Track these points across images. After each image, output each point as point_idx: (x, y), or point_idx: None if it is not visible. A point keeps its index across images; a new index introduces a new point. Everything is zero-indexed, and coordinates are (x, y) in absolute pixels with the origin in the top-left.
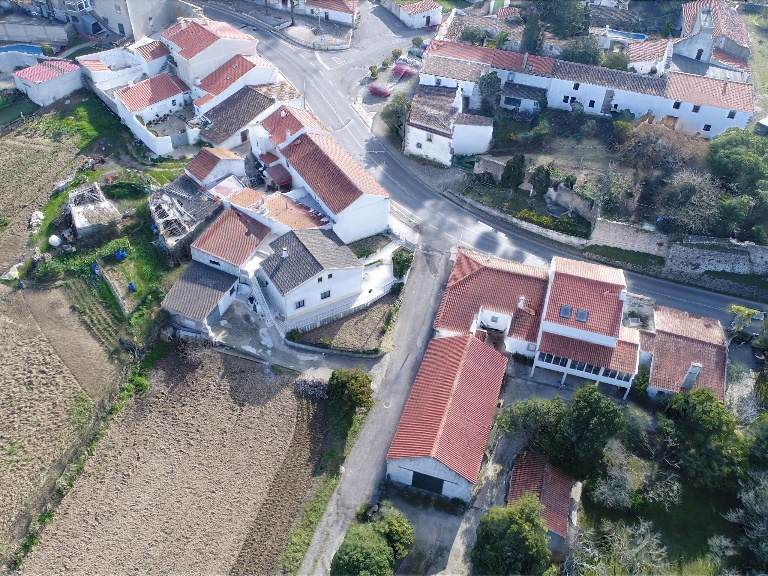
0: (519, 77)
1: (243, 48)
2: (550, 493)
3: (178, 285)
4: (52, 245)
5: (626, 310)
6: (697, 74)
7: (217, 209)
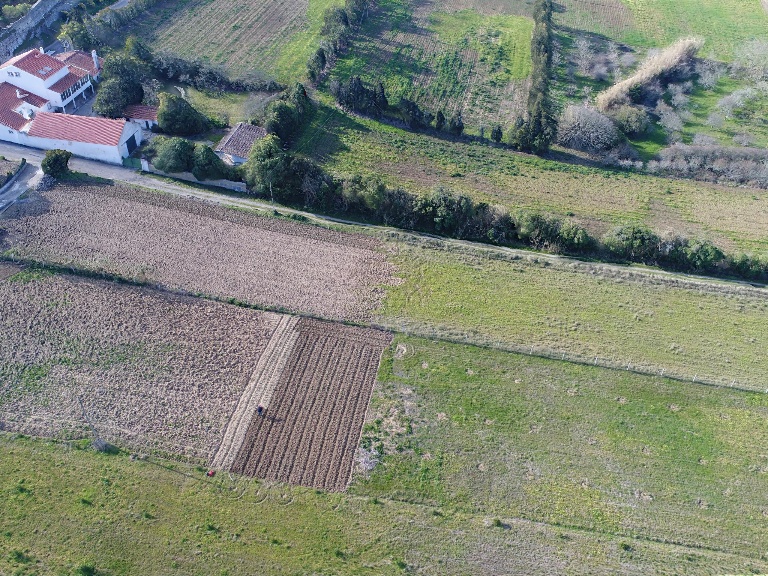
0: None
1: None
2: None
3: None
4: None
5: None
6: None
7: None
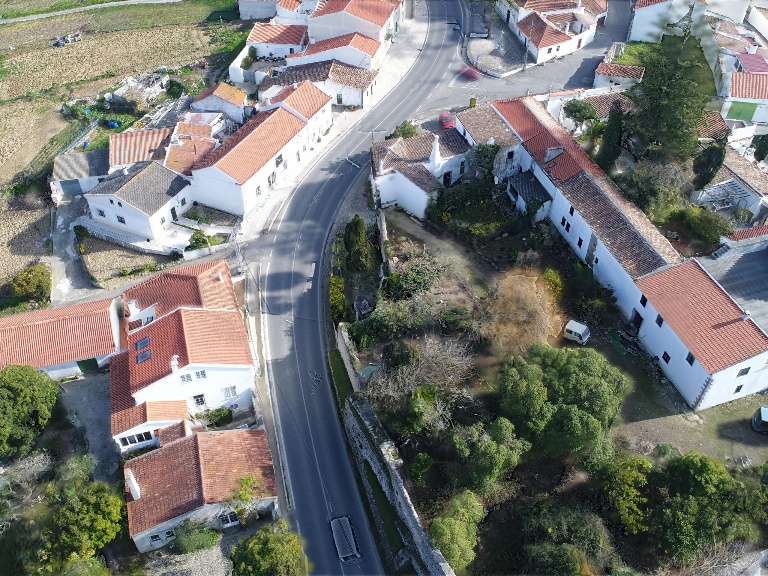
0: (538, 169)
1: (366, 28)
2: None
3: (80, 154)
4: None
5: None
6: (742, 289)
7: (171, 126)
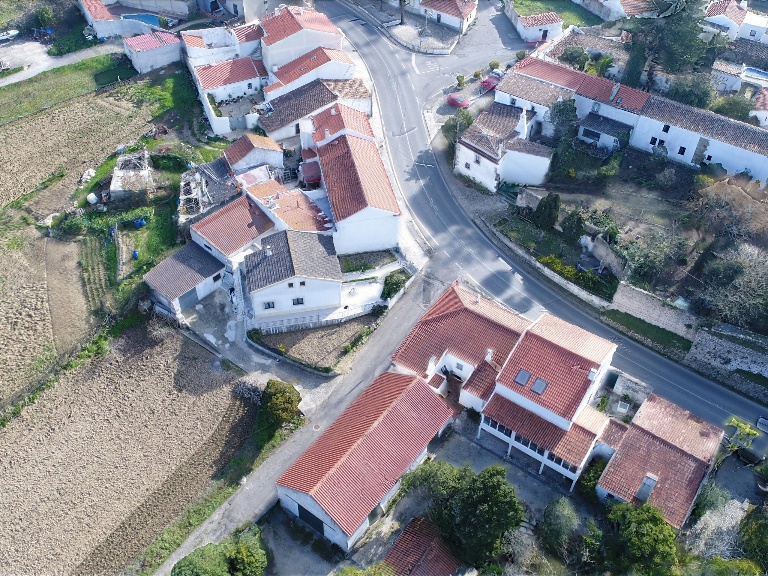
0: (604, 109)
1: (327, 41)
2: (425, 570)
3: (167, 262)
4: (89, 202)
5: (620, 391)
6: None
7: (235, 195)
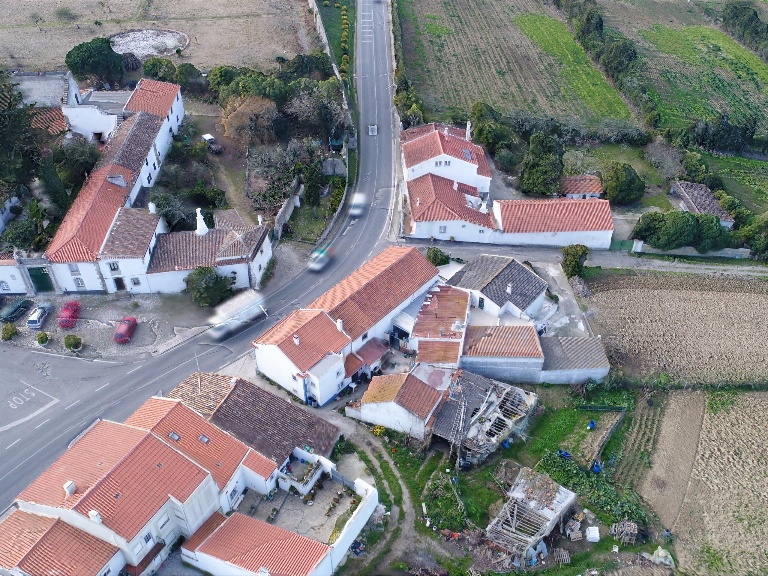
0: None
1: None
2: None
3: (581, 366)
4: None
5: None
6: None
7: (469, 372)
